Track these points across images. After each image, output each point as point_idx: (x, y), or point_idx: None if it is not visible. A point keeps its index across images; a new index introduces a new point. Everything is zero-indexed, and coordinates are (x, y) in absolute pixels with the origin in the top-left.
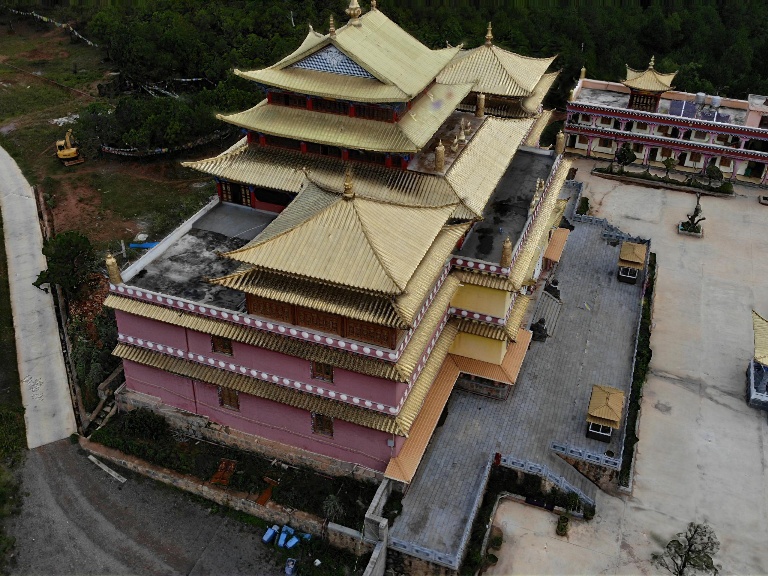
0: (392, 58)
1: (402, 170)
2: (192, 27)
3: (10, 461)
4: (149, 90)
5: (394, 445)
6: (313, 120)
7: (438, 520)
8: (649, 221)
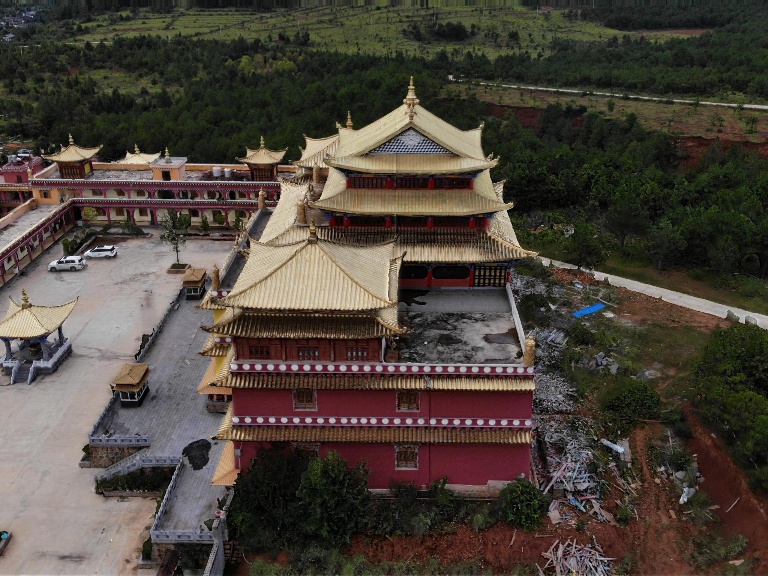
0: None
1: None
2: None
3: None
4: None
5: None
6: None
7: None
8: (46, 555)
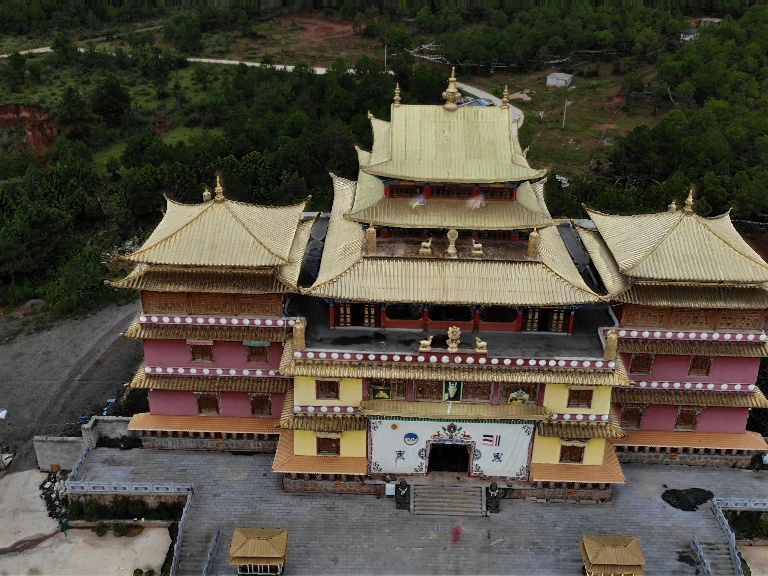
0: (439, 145)
1: None
2: (726, 145)
3: None
4: (627, 180)
5: (149, 401)
6: None
7: (117, 472)
8: None
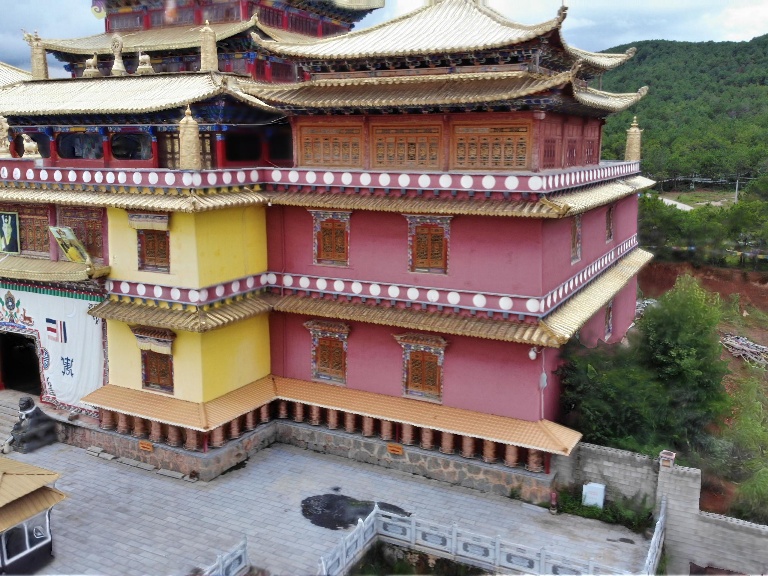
0: None
1: None
2: None
3: None
4: None
5: None
6: None
7: None
8: None
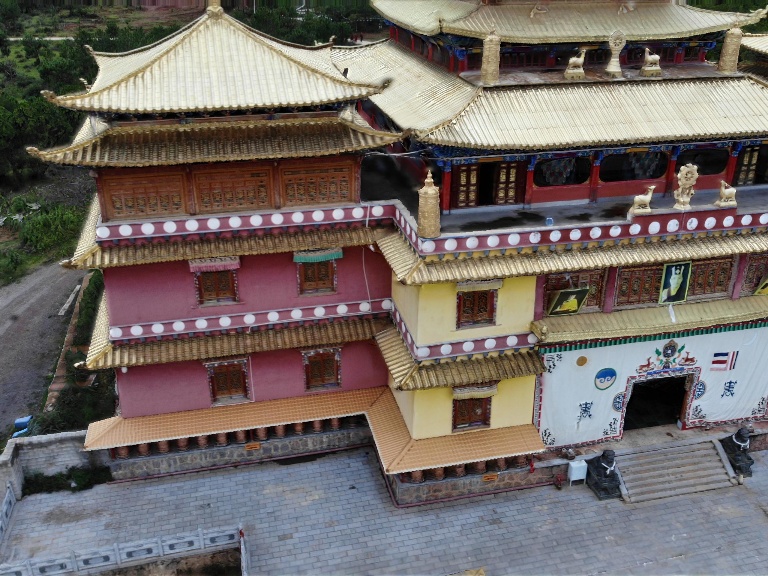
0: None
1: (456, 77)
2: None
3: (50, 259)
4: None
5: (119, 394)
6: (427, 4)
7: (79, 532)
8: None
